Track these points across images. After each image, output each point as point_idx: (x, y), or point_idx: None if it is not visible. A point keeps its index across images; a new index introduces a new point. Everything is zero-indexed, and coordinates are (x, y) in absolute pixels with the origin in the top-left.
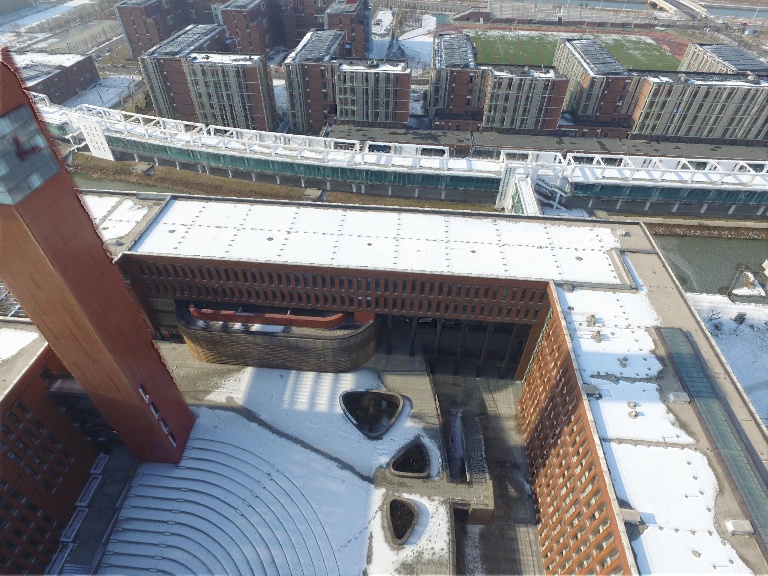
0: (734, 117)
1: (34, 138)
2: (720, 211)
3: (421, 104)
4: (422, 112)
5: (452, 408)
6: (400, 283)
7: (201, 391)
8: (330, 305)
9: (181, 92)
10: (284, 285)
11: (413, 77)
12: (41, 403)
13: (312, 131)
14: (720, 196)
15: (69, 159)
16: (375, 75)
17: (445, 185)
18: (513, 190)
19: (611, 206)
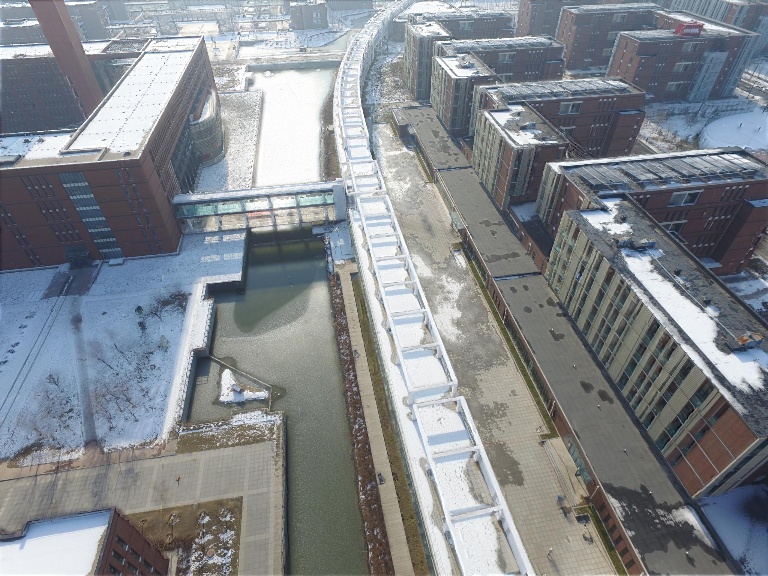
0: (635, 361)
1: None
2: None
3: None
4: None
5: None
6: None
7: None
8: None
9: None
10: None
11: None
12: None
13: None
14: None
15: None
16: None
17: None
18: None
19: None
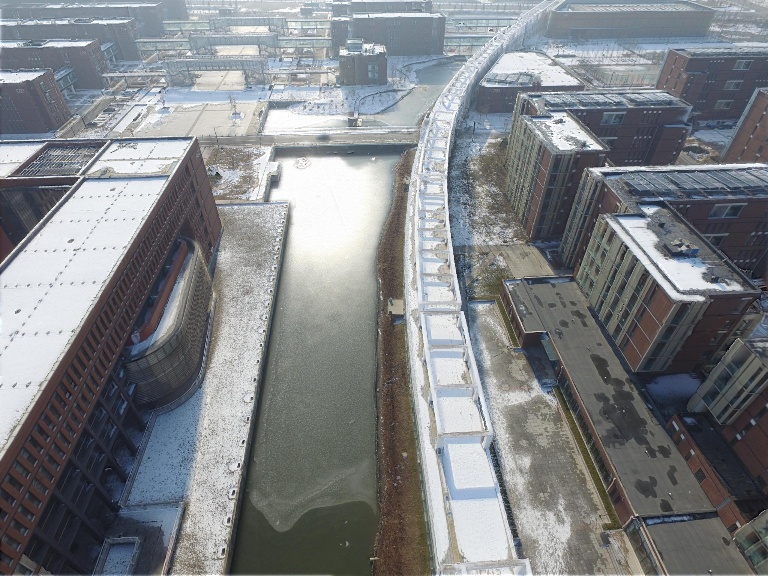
0: None
1: None
2: None
3: None
4: None
5: None
6: None
7: None
8: None
9: None
10: None
11: None
12: None
13: None
14: None
15: (416, 147)
16: (634, 260)
17: None
18: None
19: None
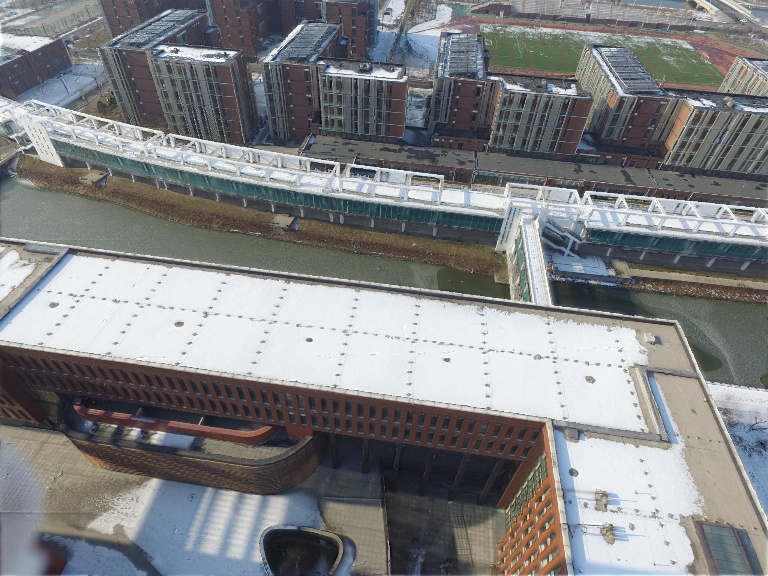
0: None
1: None
2: (765, 269)
3: (423, 112)
4: (422, 124)
5: (412, 548)
6: (342, 404)
7: (84, 514)
8: (254, 416)
9: (147, 89)
10: (190, 392)
11: (418, 78)
12: None
13: (295, 140)
14: (767, 254)
15: (14, 162)
16: (366, 82)
17: (437, 222)
18: (517, 233)
19: (633, 255)
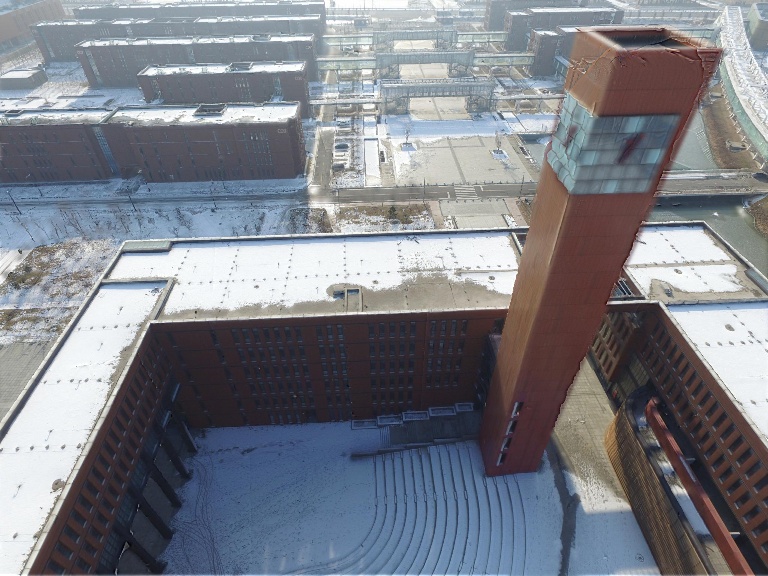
0: None
1: (653, 150)
2: None
3: None
4: None
5: None
6: None
7: (570, 462)
8: None
9: None
10: None
11: None
12: (477, 336)
13: None
14: None
15: (758, 198)
16: None
17: None
18: None
19: None
